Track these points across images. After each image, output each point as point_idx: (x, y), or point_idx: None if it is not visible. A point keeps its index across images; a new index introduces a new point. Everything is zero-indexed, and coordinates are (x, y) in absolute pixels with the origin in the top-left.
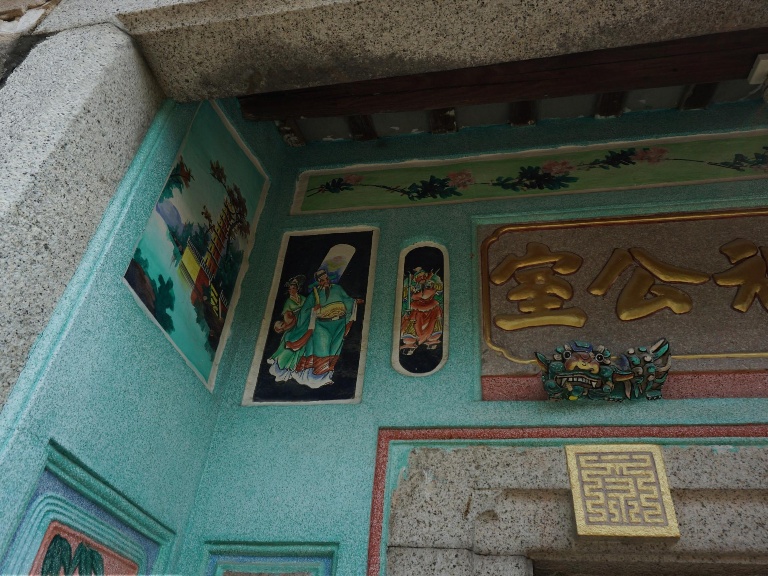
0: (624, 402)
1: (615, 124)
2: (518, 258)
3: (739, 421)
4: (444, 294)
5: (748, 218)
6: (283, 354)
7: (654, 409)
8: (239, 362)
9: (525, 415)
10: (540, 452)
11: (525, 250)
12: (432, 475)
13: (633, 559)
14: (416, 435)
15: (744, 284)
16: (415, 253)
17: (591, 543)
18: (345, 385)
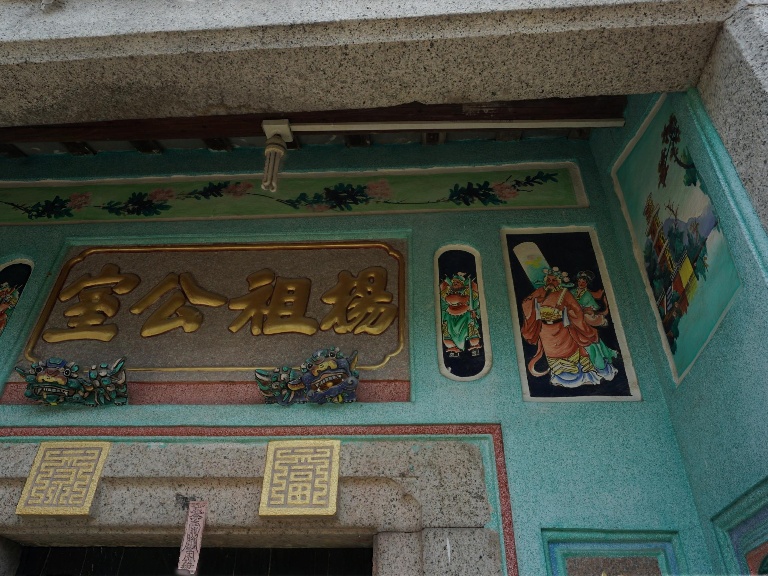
0: (98, 407)
1: (224, 158)
2: (88, 278)
3: (172, 424)
4: (14, 308)
5: (283, 251)
6: None
7: (117, 413)
8: None
9: (18, 417)
10: (20, 448)
11: (100, 271)
12: None
13: (67, 532)
14: None
15: (246, 309)
16: (8, 269)
17: (34, 520)
18: None
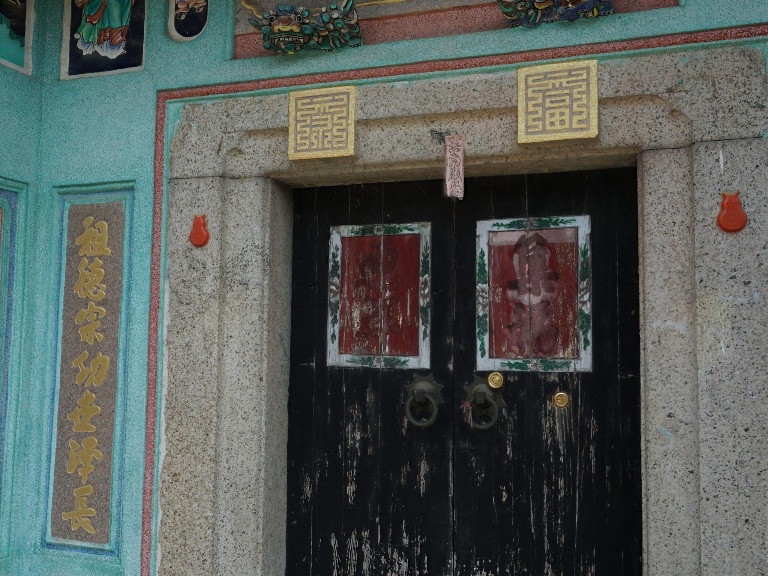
0: (334, 51)
1: None
2: None
3: (413, 60)
4: None
5: None
6: (86, 28)
7: (354, 55)
8: (51, 40)
9: (260, 70)
10: (272, 99)
11: None
12: (196, 125)
13: (336, 172)
14: (183, 94)
15: None
16: None
17: (304, 164)
18: (135, 54)
